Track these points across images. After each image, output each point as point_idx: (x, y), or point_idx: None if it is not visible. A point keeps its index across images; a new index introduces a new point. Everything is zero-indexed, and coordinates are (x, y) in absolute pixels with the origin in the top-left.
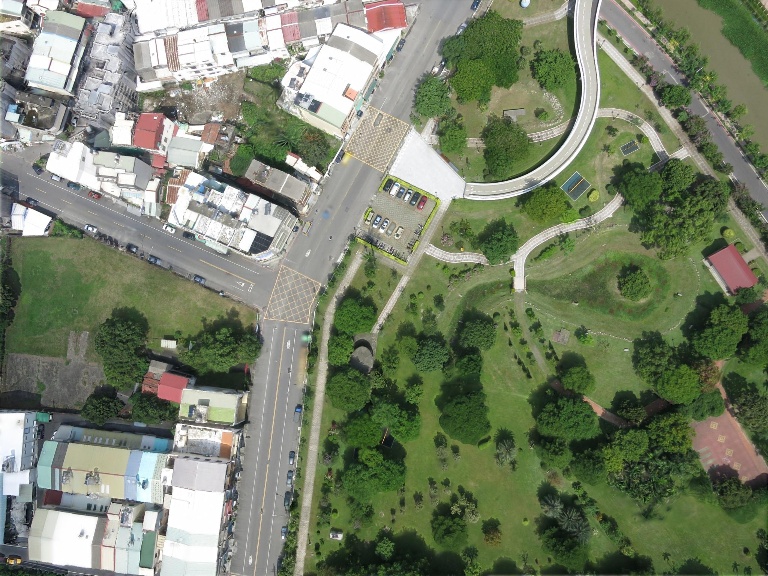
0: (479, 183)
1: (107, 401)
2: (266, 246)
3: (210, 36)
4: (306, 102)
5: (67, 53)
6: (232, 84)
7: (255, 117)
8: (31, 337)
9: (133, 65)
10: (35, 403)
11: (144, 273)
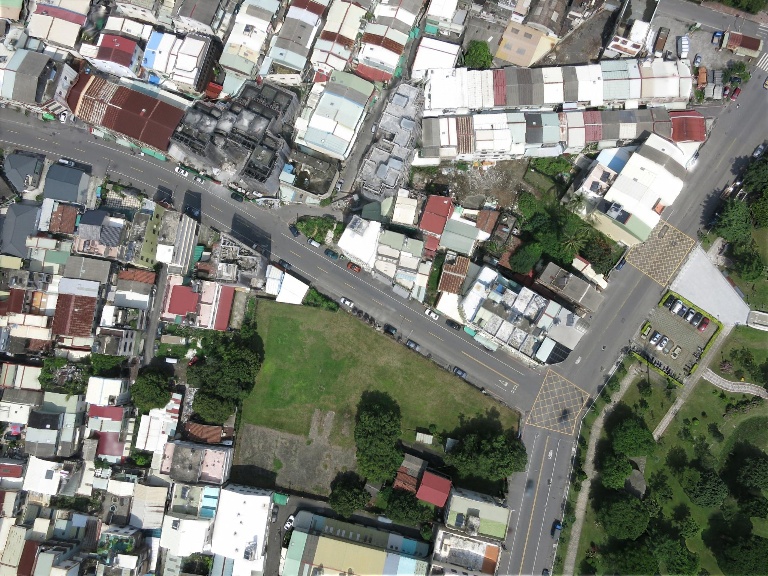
0: (767, 313)
1: (357, 493)
2: (564, 358)
3: (509, 124)
4: (615, 211)
5: (353, 118)
6: (511, 171)
7: (533, 209)
8: (271, 409)
9: (420, 141)
10: (269, 481)
11: (400, 357)
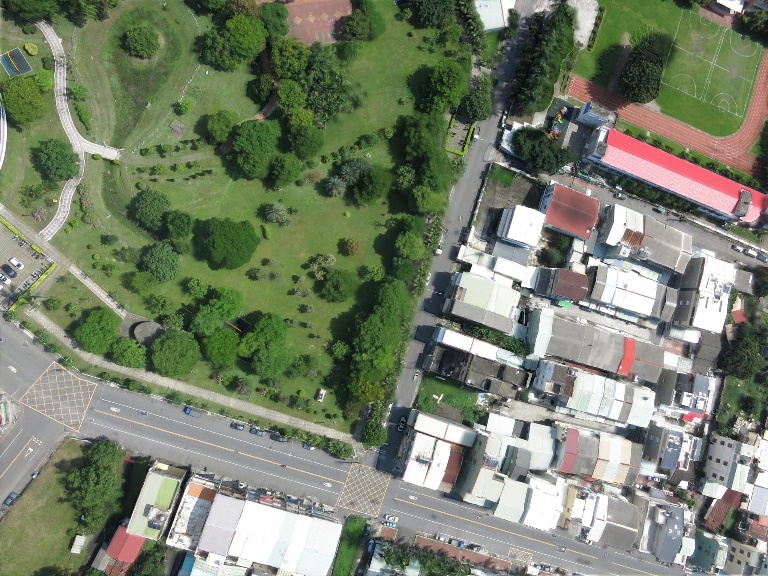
0: None
1: None
2: None
3: None
4: None
5: None
6: None
7: None
8: None
9: None
10: None
11: None
